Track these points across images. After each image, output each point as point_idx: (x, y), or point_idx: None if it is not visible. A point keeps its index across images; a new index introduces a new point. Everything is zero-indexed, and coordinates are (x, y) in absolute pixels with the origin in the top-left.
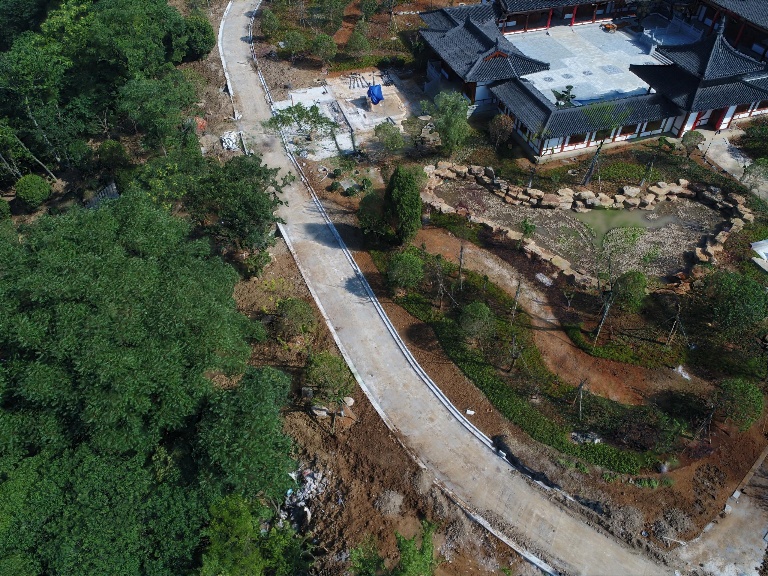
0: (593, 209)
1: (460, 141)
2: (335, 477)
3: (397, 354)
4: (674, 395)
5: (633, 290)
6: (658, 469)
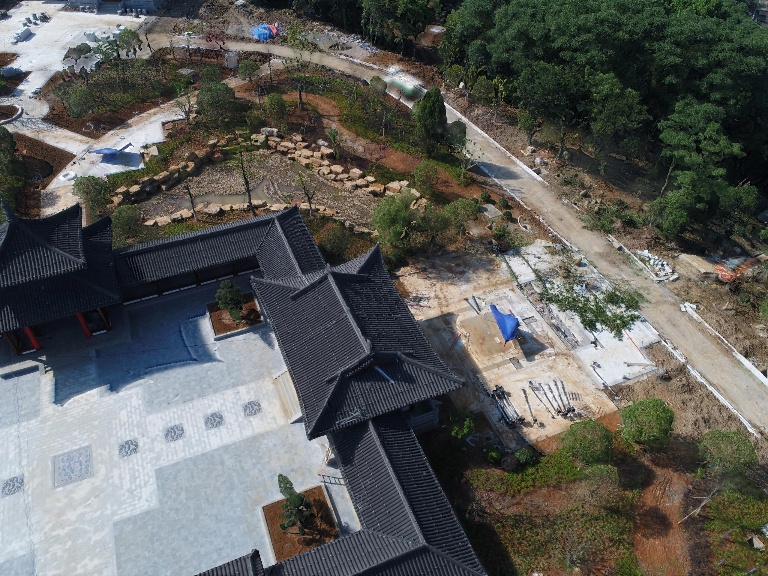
0: None
1: None
2: None
3: None
4: None
5: None
6: None
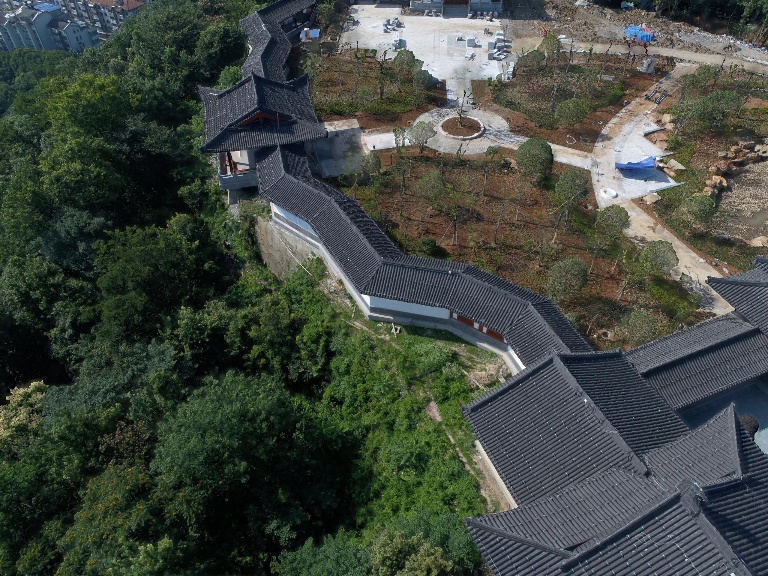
0: None
1: None
2: None
3: None
4: None
5: None
6: None
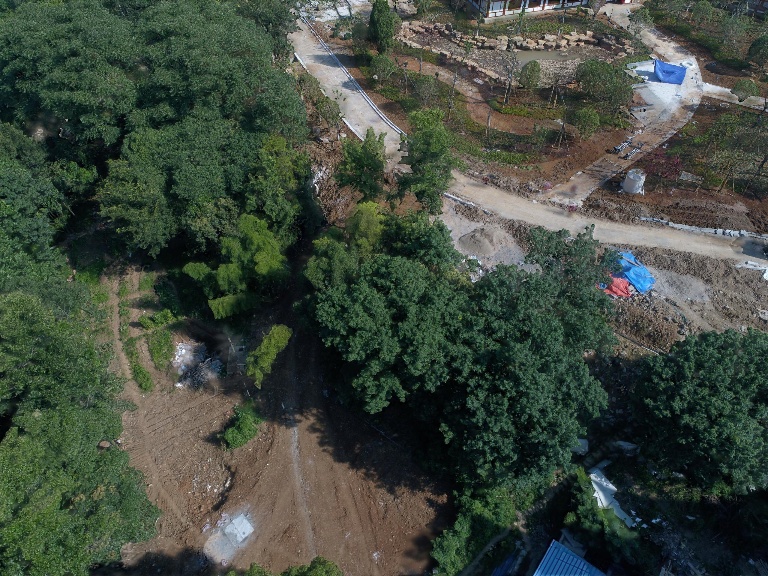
0: (522, 50)
1: (428, 4)
2: (334, 168)
3: (375, 116)
4: (552, 131)
5: (531, 73)
6: (533, 160)
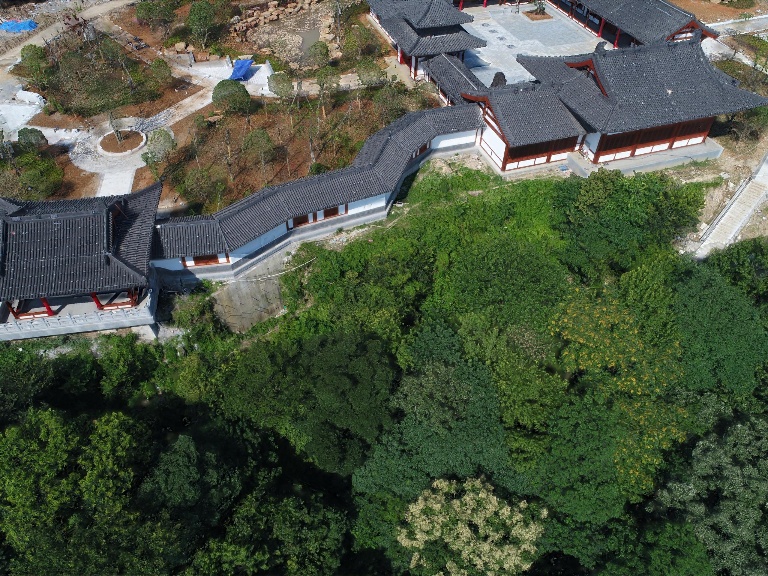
0: None
1: None
2: None
3: None
4: None
5: None
6: None
